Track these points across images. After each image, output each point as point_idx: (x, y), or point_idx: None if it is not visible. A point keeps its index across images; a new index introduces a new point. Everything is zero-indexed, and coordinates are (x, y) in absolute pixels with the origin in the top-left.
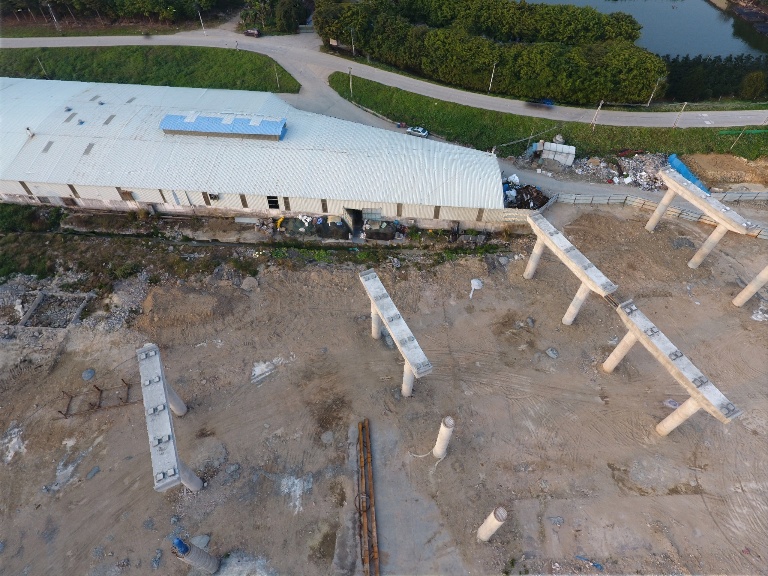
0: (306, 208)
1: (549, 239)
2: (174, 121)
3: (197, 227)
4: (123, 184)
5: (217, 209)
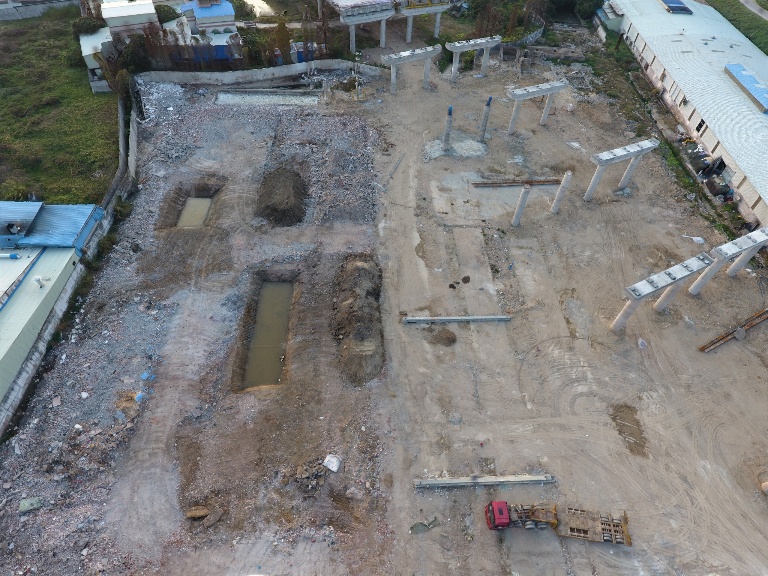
0: (708, 142)
1: None
2: (737, 68)
3: (661, 113)
4: (669, 69)
5: (680, 112)
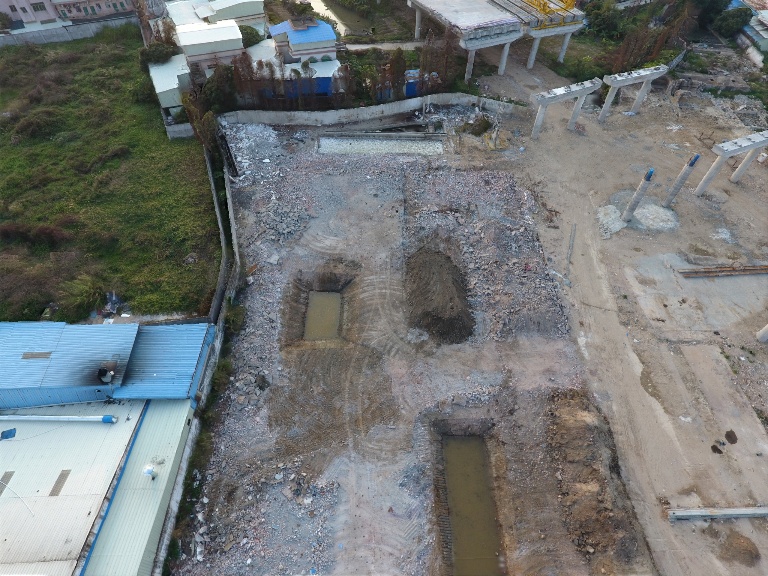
0: None
1: None
2: None
3: None
4: None
5: None
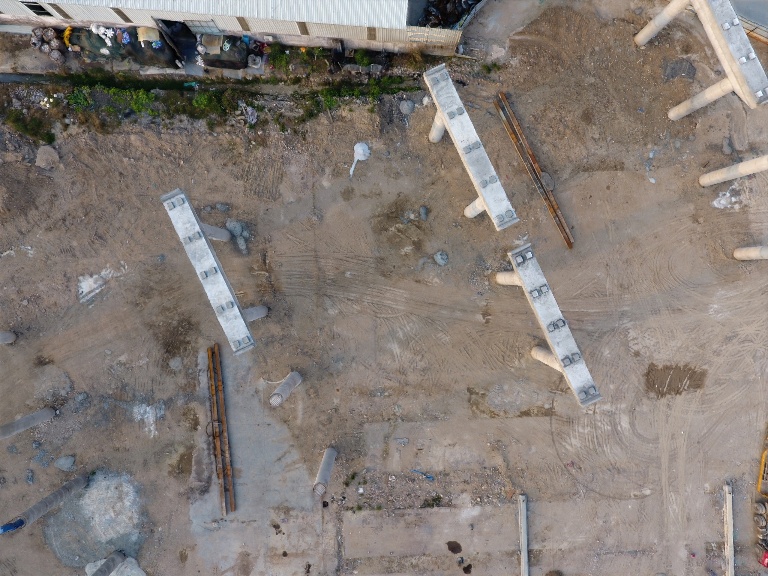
0: (95, 17)
1: (447, 124)
2: None
3: None
4: None
5: None
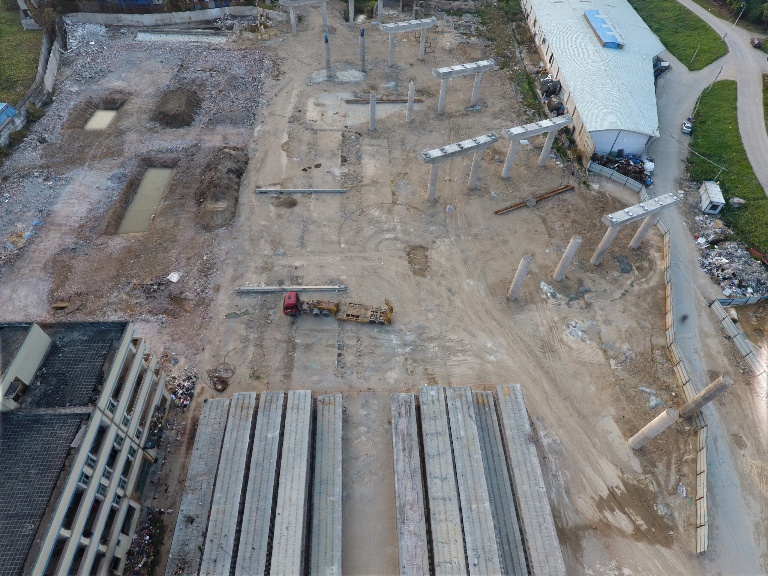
0: None
1: None
2: (593, 12)
3: (530, 53)
4: (538, 15)
5: None
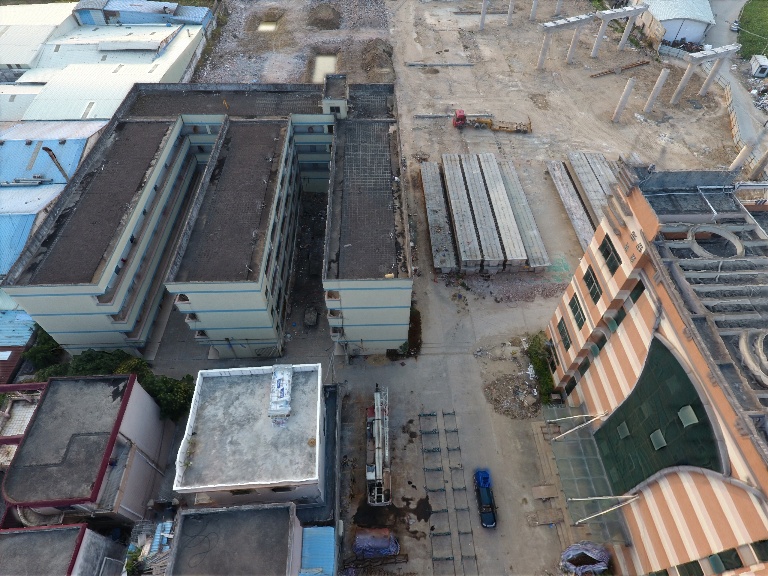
0: None
1: None
2: None
3: None
4: None
5: None
